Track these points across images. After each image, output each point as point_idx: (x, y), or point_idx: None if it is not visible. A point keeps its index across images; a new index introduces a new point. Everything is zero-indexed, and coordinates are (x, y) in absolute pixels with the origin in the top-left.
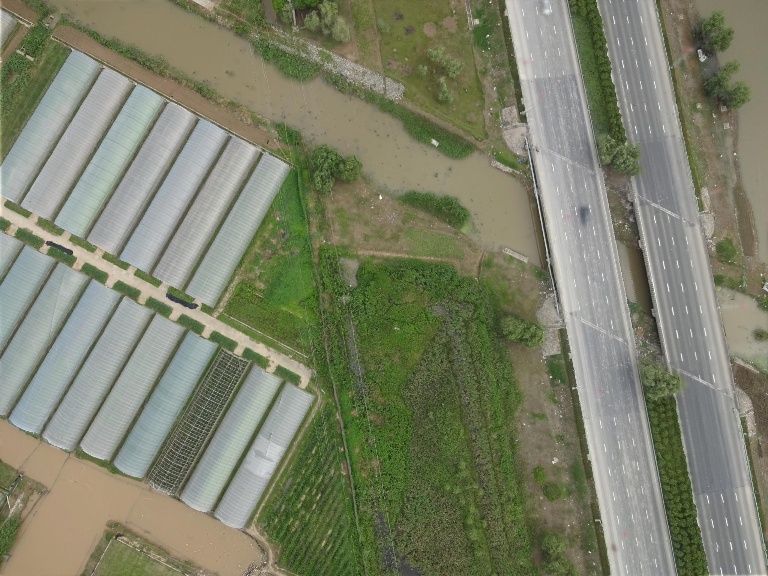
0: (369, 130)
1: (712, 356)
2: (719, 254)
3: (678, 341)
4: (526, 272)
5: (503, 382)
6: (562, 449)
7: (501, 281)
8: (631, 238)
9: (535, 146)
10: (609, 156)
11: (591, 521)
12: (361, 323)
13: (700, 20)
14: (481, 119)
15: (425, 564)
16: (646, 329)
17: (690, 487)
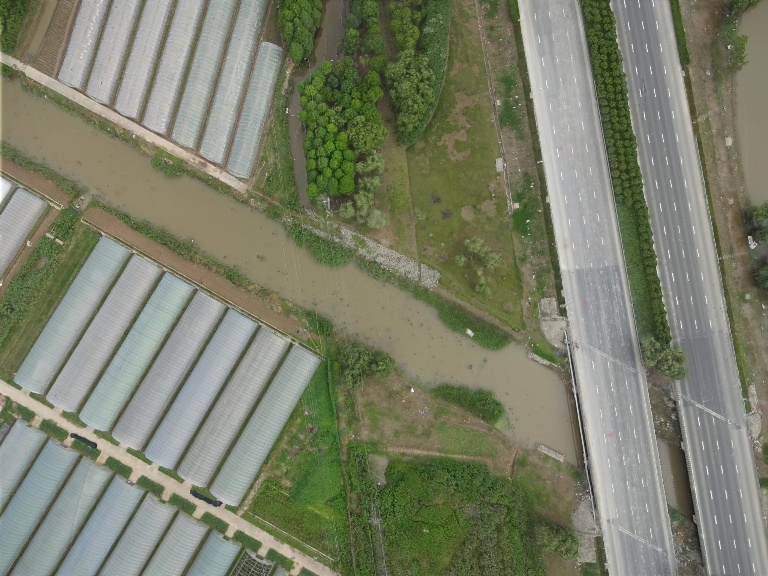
0: (402, 318)
1: (756, 569)
2: (766, 456)
3: (720, 552)
4: (562, 472)
5: None
6: None
7: (535, 481)
8: (673, 437)
9: (575, 342)
10: (653, 361)
11: None
12: (389, 525)
13: (751, 204)
14: (519, 309)
15: None
16: (686, 534)
17: None
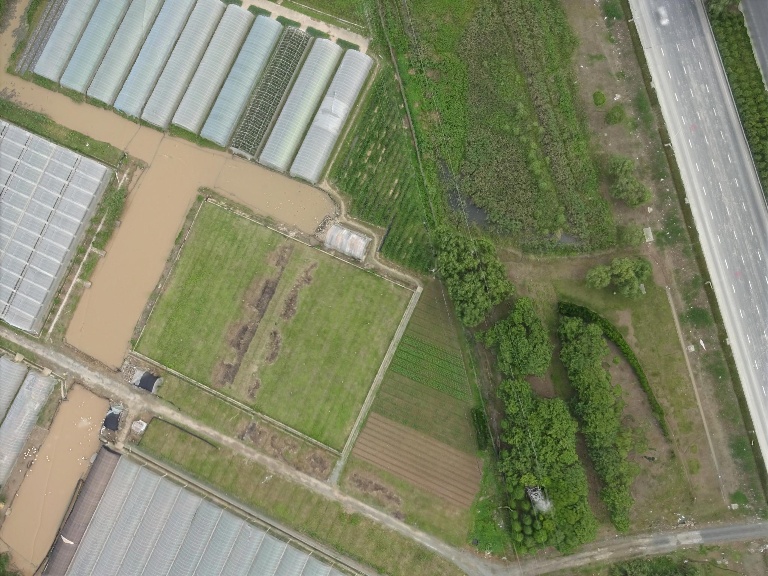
0: None
1: None
2: None
3: None
4: None
5: (556, 27)
6: (624, 85)
7: None
8: None
9: None
10: None
11: (660, 147)
12: None
13: None
14: None
15: (490, 201)
16: None
17: (767, 98)
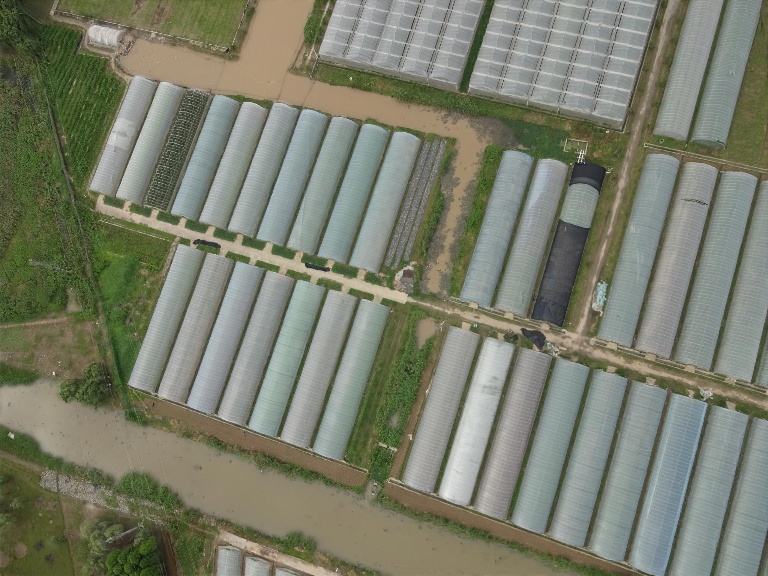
0: (69, 436)
1: None
2: None
3: None
4: None
5: None
6: None
7: None
8: None
9: None
10: None
11: None
12: None
13: None
14: None
15: None
16: None
17: None
